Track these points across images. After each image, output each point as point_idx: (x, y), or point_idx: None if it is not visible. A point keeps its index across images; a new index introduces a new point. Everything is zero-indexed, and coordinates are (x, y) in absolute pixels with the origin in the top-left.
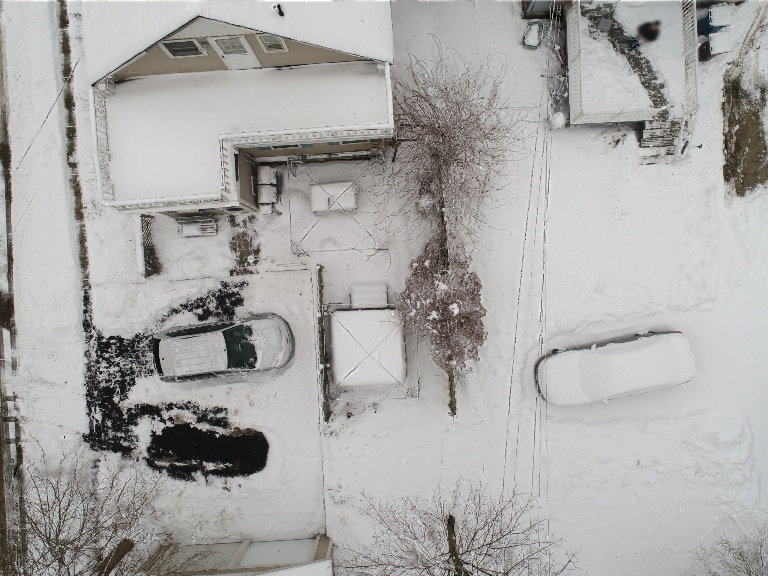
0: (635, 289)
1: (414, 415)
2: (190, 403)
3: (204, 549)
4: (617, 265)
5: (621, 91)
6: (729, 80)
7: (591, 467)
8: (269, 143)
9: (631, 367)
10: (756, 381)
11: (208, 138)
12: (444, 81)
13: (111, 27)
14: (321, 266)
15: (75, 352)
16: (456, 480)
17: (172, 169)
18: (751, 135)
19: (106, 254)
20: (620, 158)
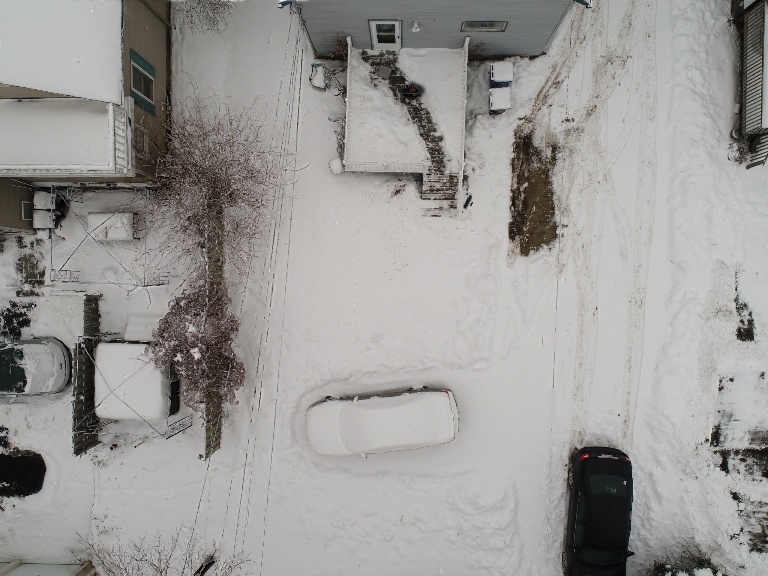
0: (411, 342)
1: (184, 451)
2: None
3: None
4: (395, 316)
5: (393, 142)
6: (520, 136)
7: (354, 519)
8: (6, 174)
9: (386, 424)
10: (526, 446)
11: None
12: (207, 120)
13: None
14: (99, 295)
15: None
16: (178, 527)
17: None
18: (540, 194)
19: None
20: (401, 208)
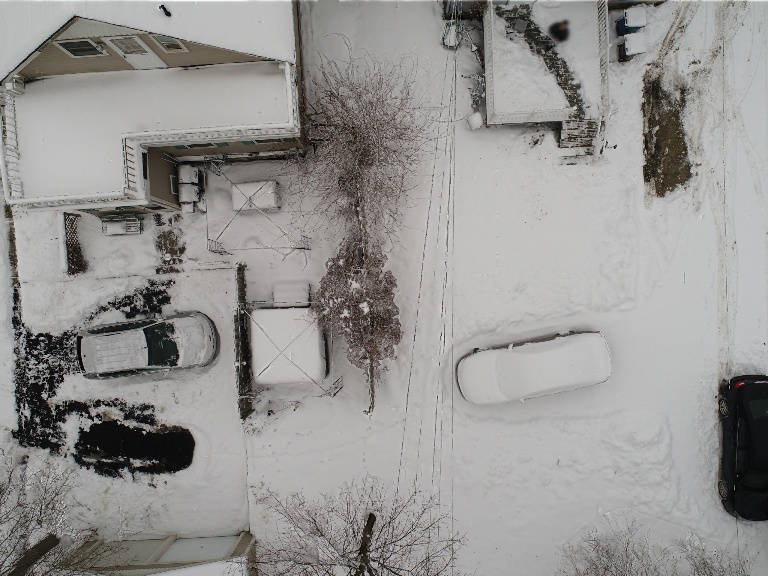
0: (555, 289)
1: (336, 413)
2: (117, 400)
3: (129, 545)
4: (538, 265)
5: (536, 91)
6: (649, 81)
7: (511, 466)
8: (176, 142)
9: (546, 366)
10: (675, 381)
11: (115, 137)
12: (357, 81)
13: (9, 27)
14: (244, 265)
15: (4, 349)
16: None
17: (80, 167)
18: (671, 136)
19: (33, 252)
20: (539, 158)
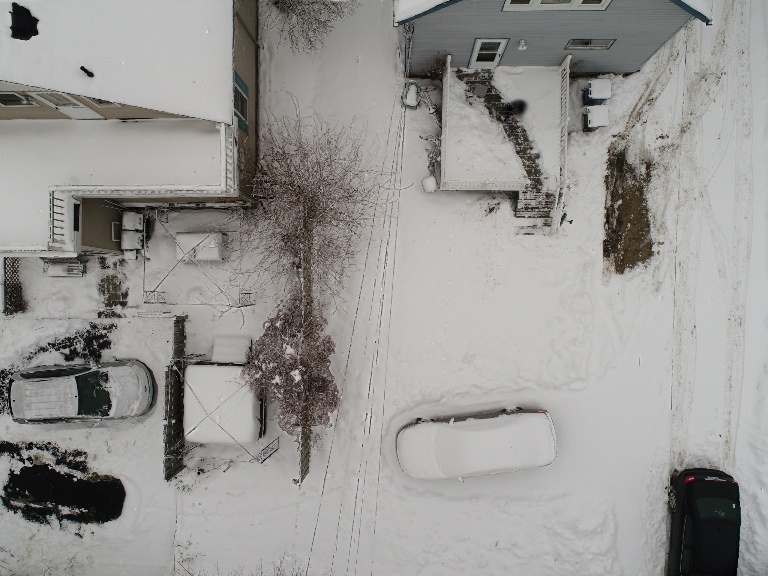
0: (504, 362)
1: (270, 475)
2: (50, 444)
3: None
4: (488, 336)
5: (491, 160)
6: (614, 153)
7: (447, 544)
8: (109, 195)
9: (485, 446)
10: (624, 468)
11: (46, 187)
12: (305, 140)
13: None
14: (185, 316)
15: None
16: None
17: (8, 216)
18: (634, 211)
19: None
20: (495, 226)
